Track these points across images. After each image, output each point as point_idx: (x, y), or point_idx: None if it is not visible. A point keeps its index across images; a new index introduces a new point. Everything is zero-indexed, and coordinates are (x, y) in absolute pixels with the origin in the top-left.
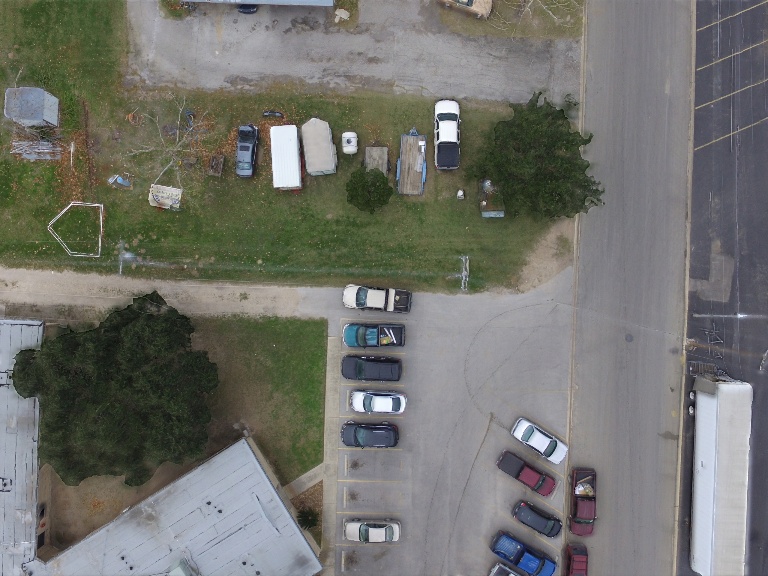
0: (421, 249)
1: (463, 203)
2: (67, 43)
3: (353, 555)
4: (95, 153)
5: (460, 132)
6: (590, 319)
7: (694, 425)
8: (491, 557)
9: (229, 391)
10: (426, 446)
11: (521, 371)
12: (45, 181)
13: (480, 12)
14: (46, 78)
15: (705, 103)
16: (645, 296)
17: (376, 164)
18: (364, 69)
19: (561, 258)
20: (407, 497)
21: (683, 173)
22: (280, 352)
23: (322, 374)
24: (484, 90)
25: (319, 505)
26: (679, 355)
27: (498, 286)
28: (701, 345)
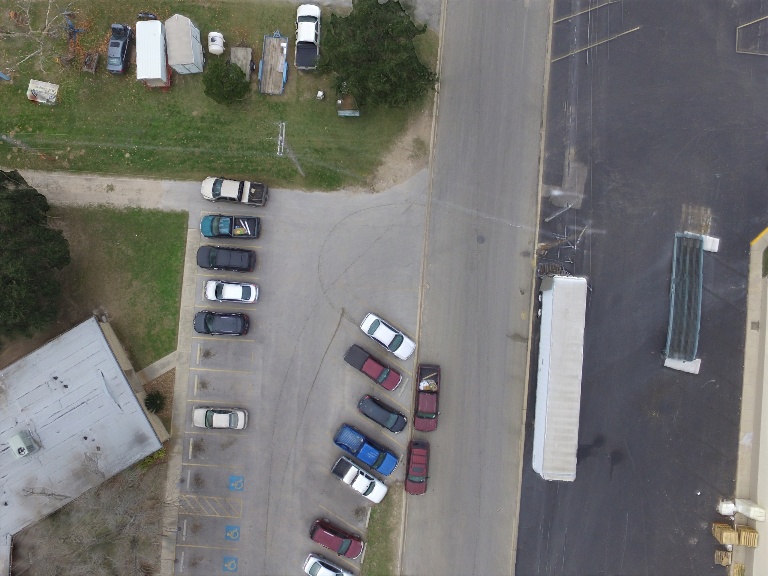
0: None
1: (323, 104)
2: None
3: (201, 443)
4: None
5: (322, 37)
6: (443, 220)
7: (540, 326)
8: (337, 451)
9: (91, 278)
10: (278, 338)
11: (373, 268)
12: None
13: None
14: None
15: (563, 18)
16: (497, 200)
17: (240, 64)
18: None
19: (417, 160)
20: (257, 388)
21: (539, 83)
22: (141, 242)
23: (180, 264)
24: None
25: (170, 392)
26: (530, 259)
27: (354, 185)
28: (548, 246)
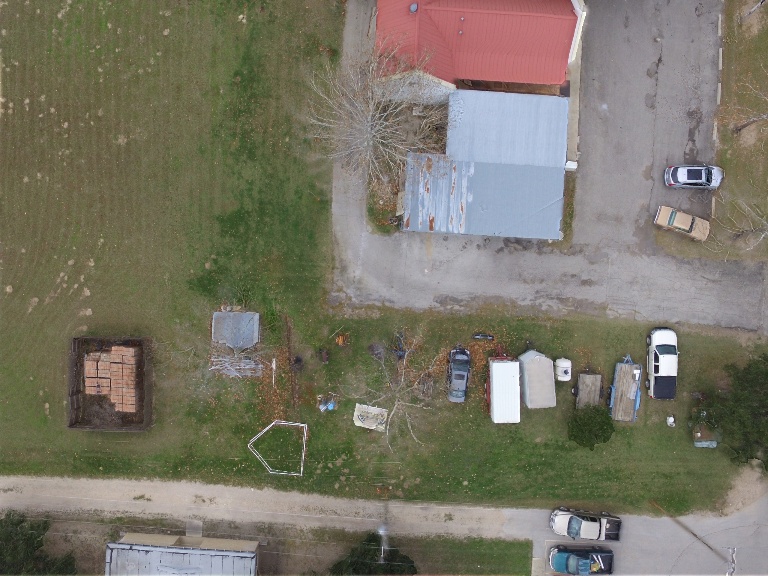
0: (628, 472)
1: (672, 427)
2: (268, 255)
3: None
4: (297, 370)
5: None
6: None
7: None
8: None
9: None
10: None
11: None
12: (245, 398)
13: (699, 238)
14: (245, 290)
15: None
16: None
17: (589, 390)
18: (577, 292)
19: (765, 481)
20: None
21: None
22: (484, 573)
23: None
24: (697, 314)
25: None
26: None
27: (702, 509)
28: None
